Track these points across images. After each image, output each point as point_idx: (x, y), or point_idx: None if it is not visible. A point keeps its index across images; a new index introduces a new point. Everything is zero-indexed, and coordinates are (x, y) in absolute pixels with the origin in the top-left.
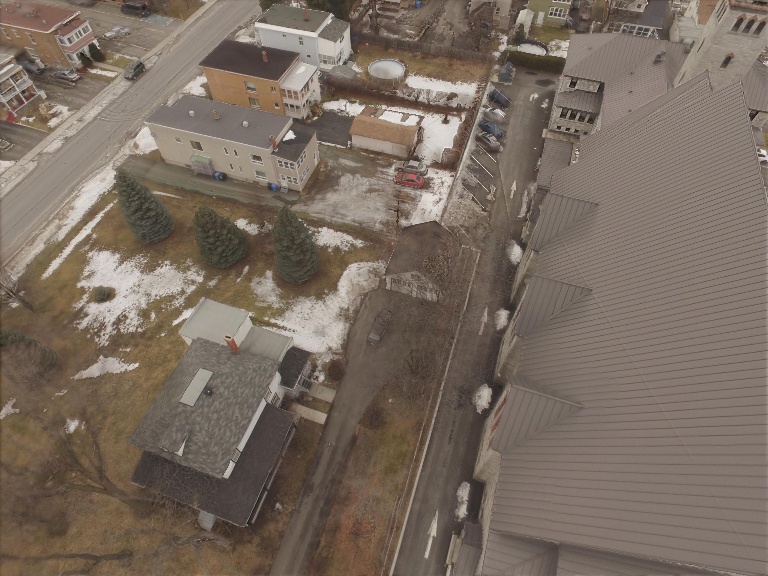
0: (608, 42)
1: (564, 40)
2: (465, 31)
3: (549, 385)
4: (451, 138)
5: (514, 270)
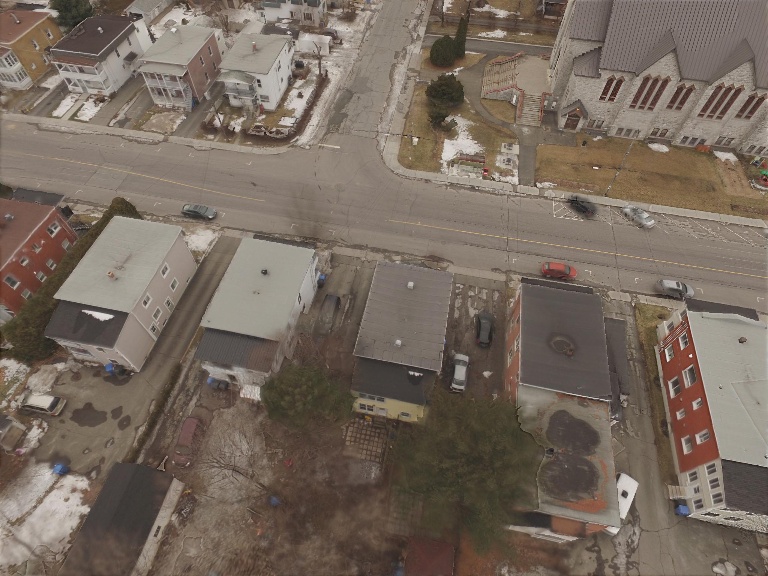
0: None
1: None
2: None
3: None
4: None
5: None
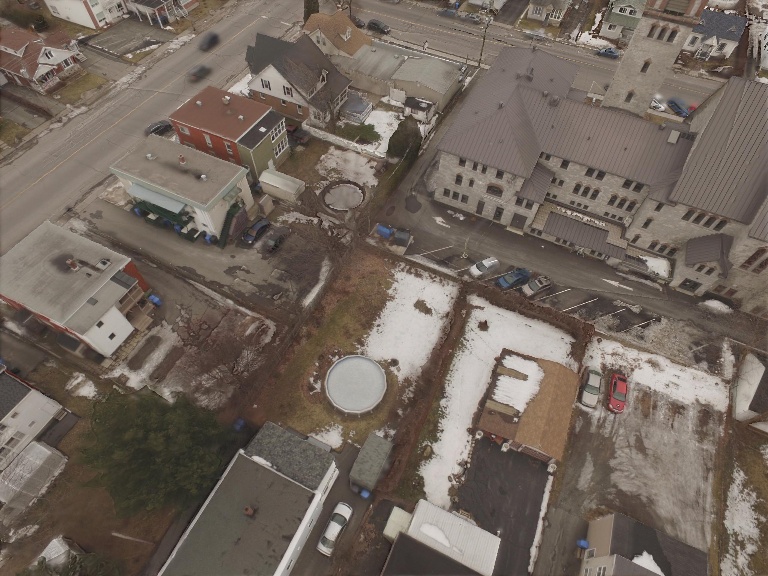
0: (510, 123)
1: (320, 161)
2: (261, 255)
3: None
4: (520, 327)
5: (741, 313)
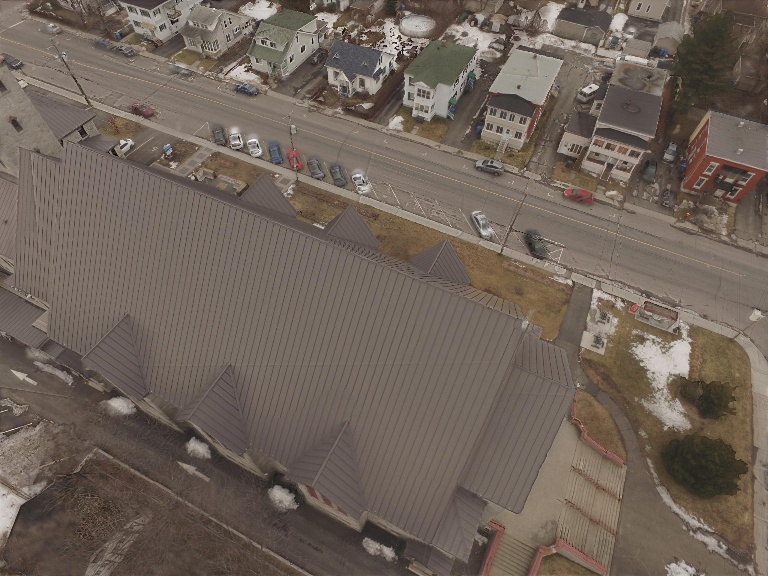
0: None
1: None
2: None
3: (314, 442)
4: None
5: (142, 415)
